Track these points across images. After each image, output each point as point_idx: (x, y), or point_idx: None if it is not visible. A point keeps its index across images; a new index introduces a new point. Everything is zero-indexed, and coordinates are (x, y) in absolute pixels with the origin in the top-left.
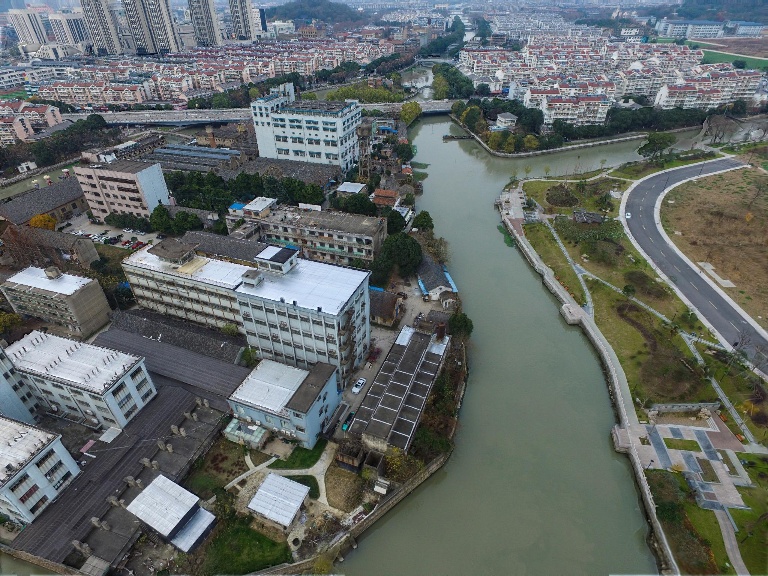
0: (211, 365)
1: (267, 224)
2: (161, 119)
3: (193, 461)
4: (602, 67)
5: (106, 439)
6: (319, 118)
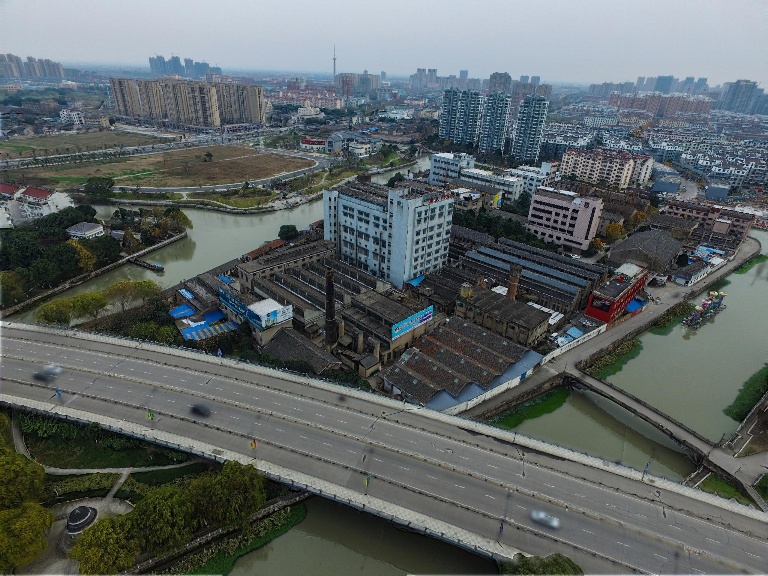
0: None
1: None
2: (767, 537)
3: None
4: None
5: None
6: None
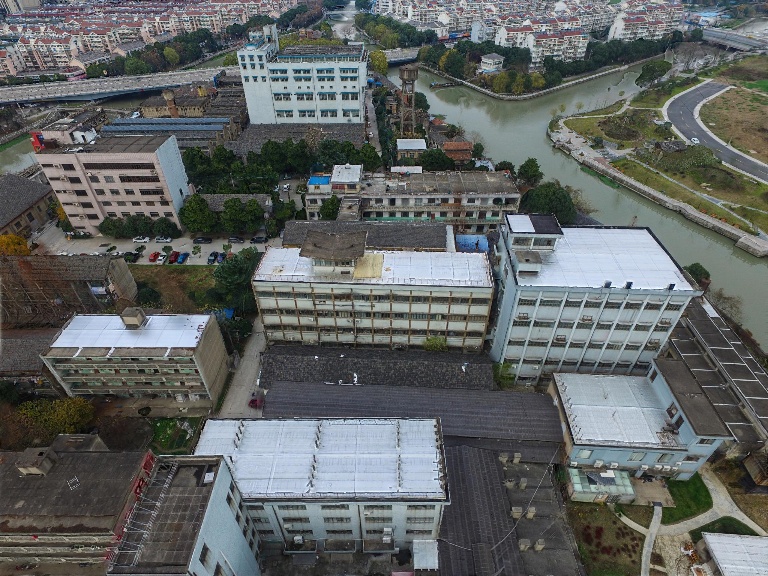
0: (477, 401)
1: (369, 198)
2: (62, 93)
3: (578, 552)
4: (534, 8)
5: (426, 564)
6: (335, 64)
